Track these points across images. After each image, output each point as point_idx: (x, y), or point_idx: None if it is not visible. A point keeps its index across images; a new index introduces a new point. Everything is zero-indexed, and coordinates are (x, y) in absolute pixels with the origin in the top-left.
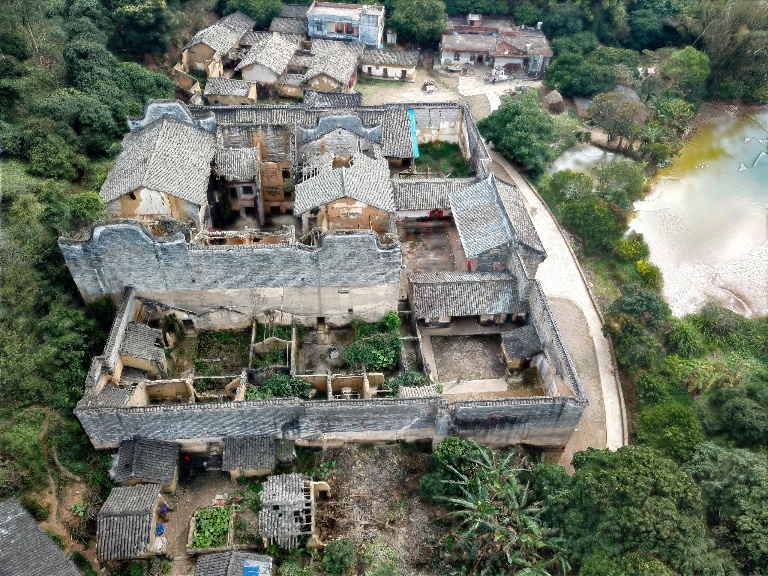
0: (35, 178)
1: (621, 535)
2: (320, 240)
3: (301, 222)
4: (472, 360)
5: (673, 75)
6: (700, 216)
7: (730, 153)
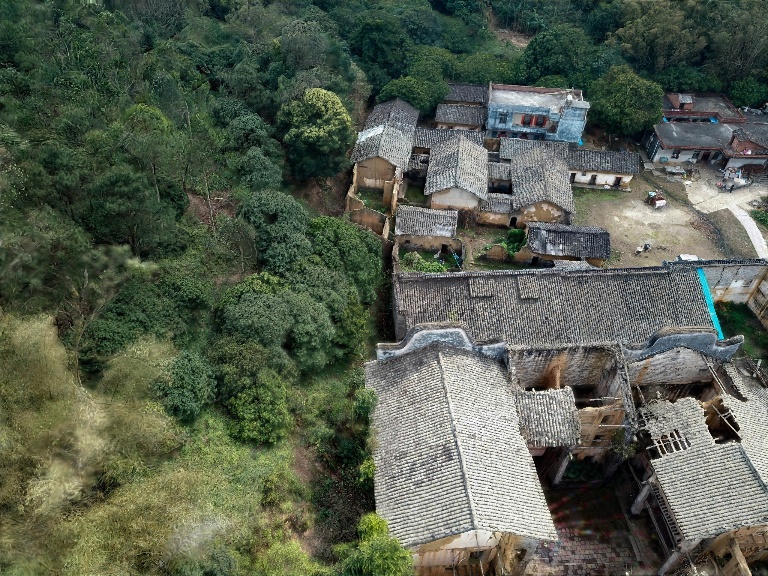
0: (246, 448)
1: None
2: None
3: None
4: None
5: None
6: None
7: None
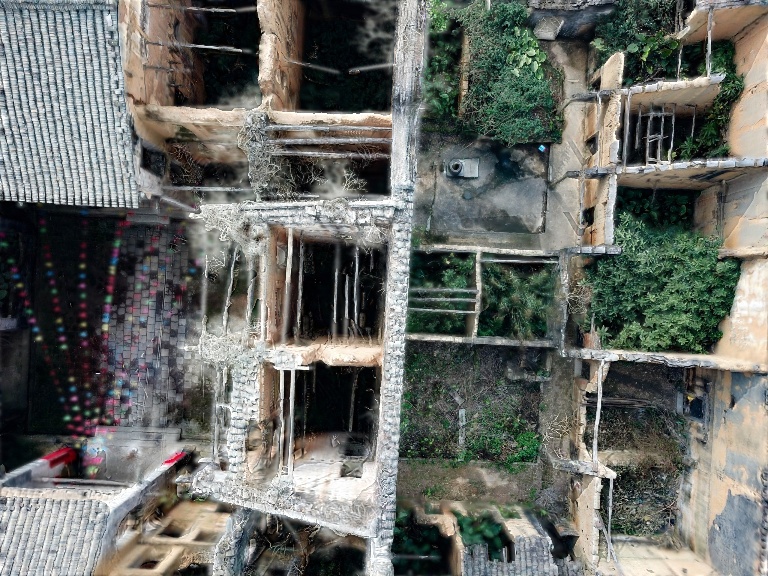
0: None
1: None
2: (417, 101)
3: (14, 217)
4: None
5: None
6: None
7: None
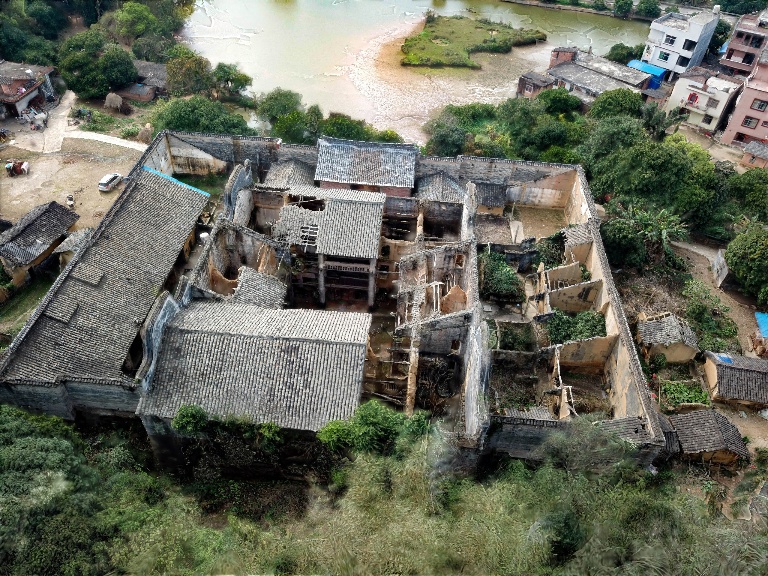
0: (182, 571)
1: (676, 177)
2: None
3: None
4: (490, 233)
5: (142, 32)
6: (318, 100)
7: (243, 62)
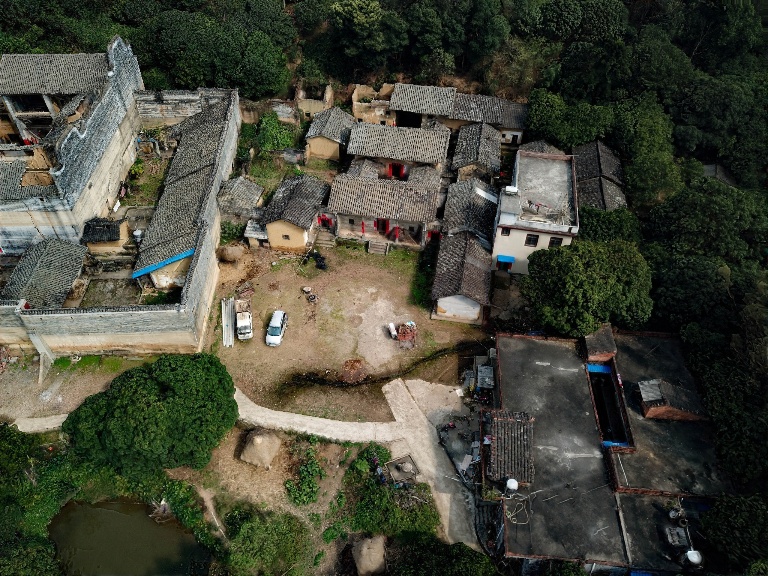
0: None
1: None
2: None
3: None
4: None
5: None
6: None
7: None
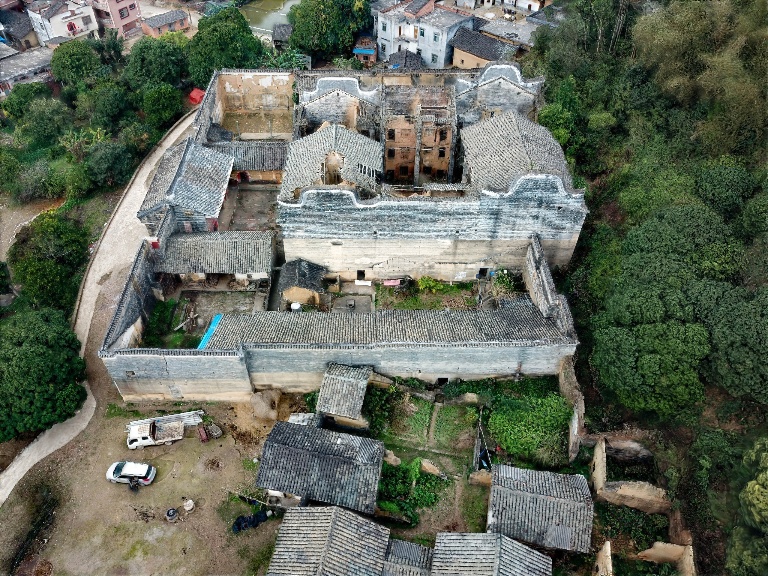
0: None
1: None
2: None
3: None
4: None
5: None
6: None
7: None
